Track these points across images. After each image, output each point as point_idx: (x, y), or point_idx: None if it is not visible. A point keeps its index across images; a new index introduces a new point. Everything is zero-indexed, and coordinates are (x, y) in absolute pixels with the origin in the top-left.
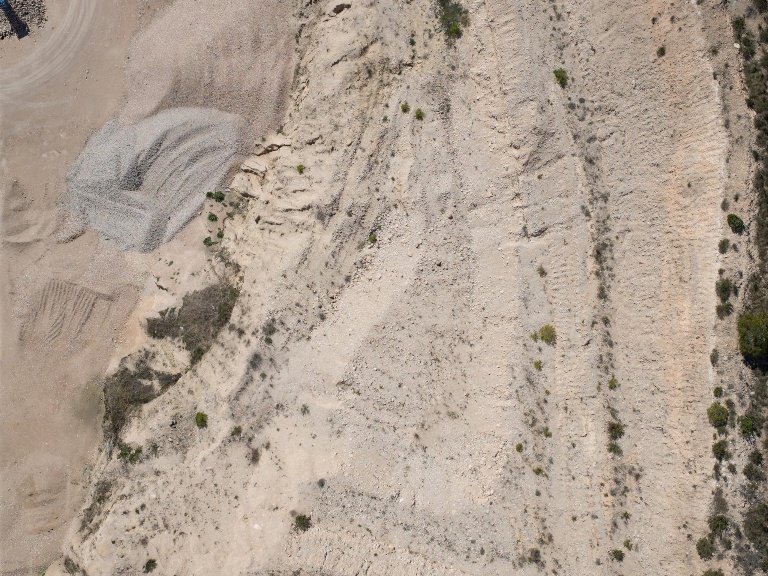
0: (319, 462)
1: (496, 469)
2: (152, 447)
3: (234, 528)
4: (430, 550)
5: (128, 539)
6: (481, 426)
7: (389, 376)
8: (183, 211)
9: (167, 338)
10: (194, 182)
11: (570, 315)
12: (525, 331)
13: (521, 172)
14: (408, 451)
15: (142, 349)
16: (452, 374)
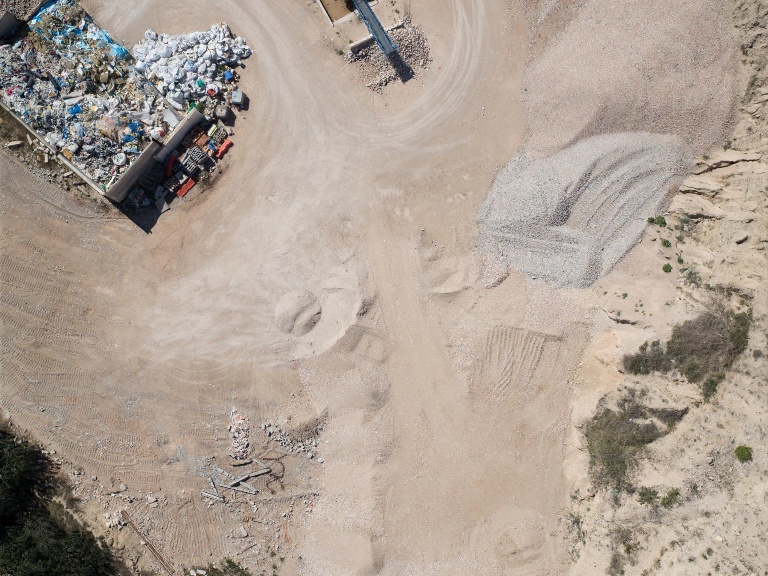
0: None
1: None
2: (691, 488)
3: None
4: None
5: None
6: None
7: None
8: (620, 240)
9: (655, 373)
10: (630, 209)
11: None
12: None
13: None
14: None
15: (622, 388)
16: None
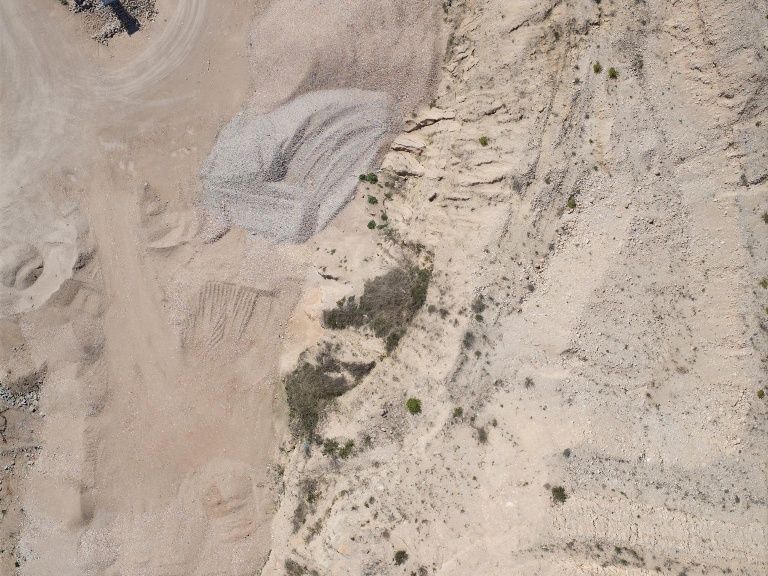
0: (558, 433)
1: (738, 418)
2: (365, 439)
3: (482, 509)
4: (687, 505)
5: (368, 534)
6: (714, 378)
7: (614, 339)
8: (334, 197)
9: (350, 328)
10: (343, 166)
11: None
12: (753, 279)
13: (735, 121)
14: (642, 411)
15: (321, 342)
16: (677, 330)
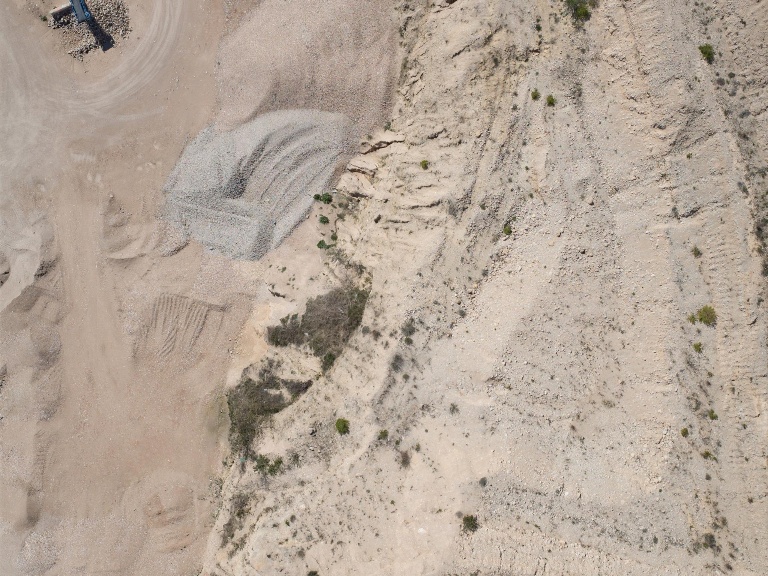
0: (477, 461)
1: (661, 456)
2: (293, 457)
3: (396, 534)
4: (602, 542)
5: (284, 552)
6: (640, 413)
7: (540, 369)
8: (290, 215)
9: (291, 345)
10: (300, 185)
11: (732, 294)
12: (681, 314)
13: (667, 152)
14: (566, 443)
15: (264, 358)
16: (605, 362)
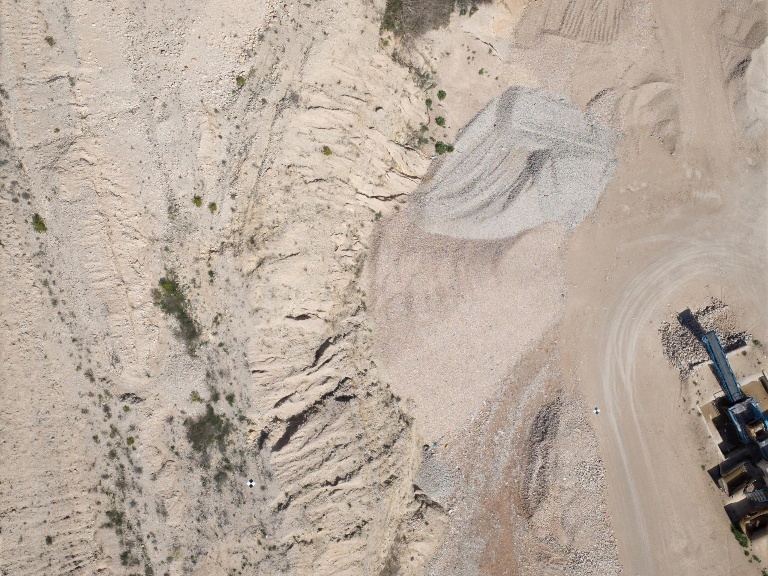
0: None
1: None
2: None
3: None
4: None
5: None
6: None
7: None
8: (479, 132)
9: None
10: (470, 162)
11: None
12: None
13: (79, 137)
14: None
15: None
16: None
